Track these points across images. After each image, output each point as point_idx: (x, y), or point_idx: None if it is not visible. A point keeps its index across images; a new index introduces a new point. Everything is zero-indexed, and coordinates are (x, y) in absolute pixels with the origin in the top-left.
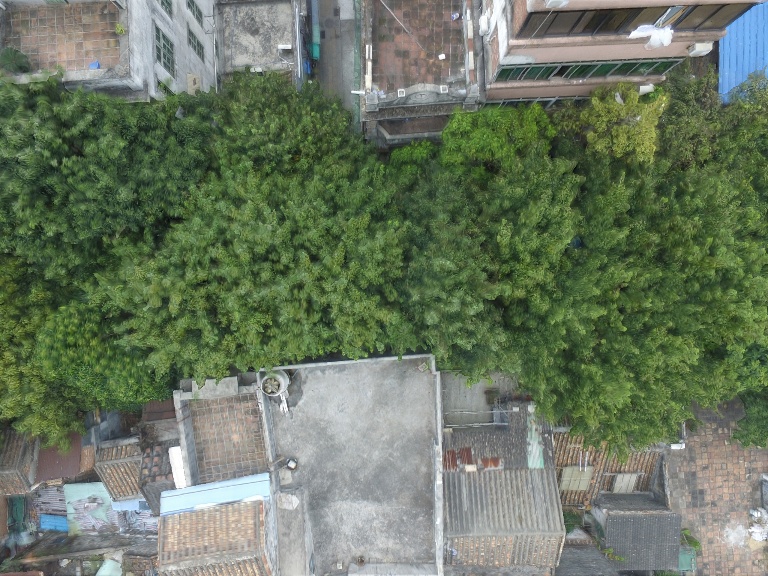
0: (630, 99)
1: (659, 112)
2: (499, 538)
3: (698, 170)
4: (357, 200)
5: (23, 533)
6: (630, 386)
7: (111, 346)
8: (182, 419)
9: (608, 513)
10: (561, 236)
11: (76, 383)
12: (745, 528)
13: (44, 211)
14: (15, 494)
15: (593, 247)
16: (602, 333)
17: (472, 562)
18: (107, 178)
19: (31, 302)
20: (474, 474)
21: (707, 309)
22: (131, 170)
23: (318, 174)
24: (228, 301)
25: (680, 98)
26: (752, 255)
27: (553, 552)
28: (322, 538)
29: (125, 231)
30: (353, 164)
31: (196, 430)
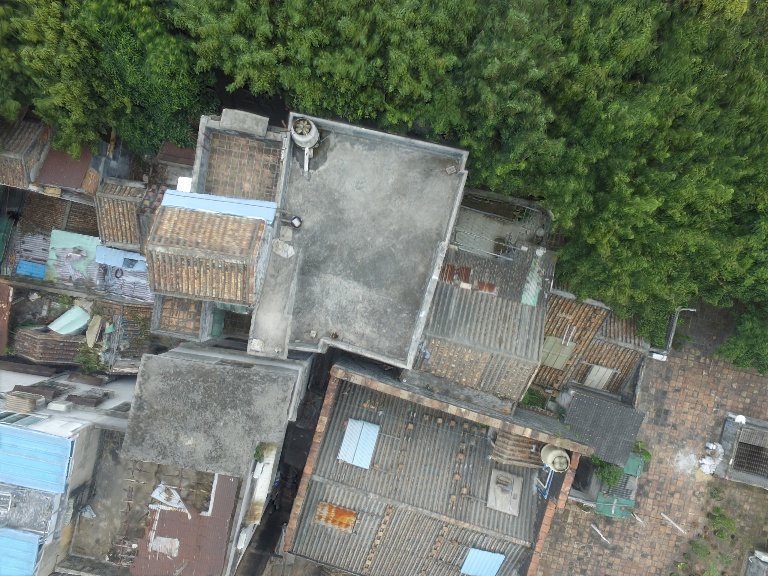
0: None
1: None
2: (475, 352)
3: None
4: None
5: None
6: (657, 205)
7: None
8: (202, 145)
9: (575, 394)
10: None
11: (115, 53)
12: (696, 458)
13: None
14: None
15: (657, 81)
16: (638, 173)
17: (440, 372)
18: None
19: None
20: (467, 292)
21: (751, 164)
22: None
23: None
24: (293, 4)
25: None
26: None
27: (522, 383)
28: (303, 305)
29: None
30: None
31: (211, 168)
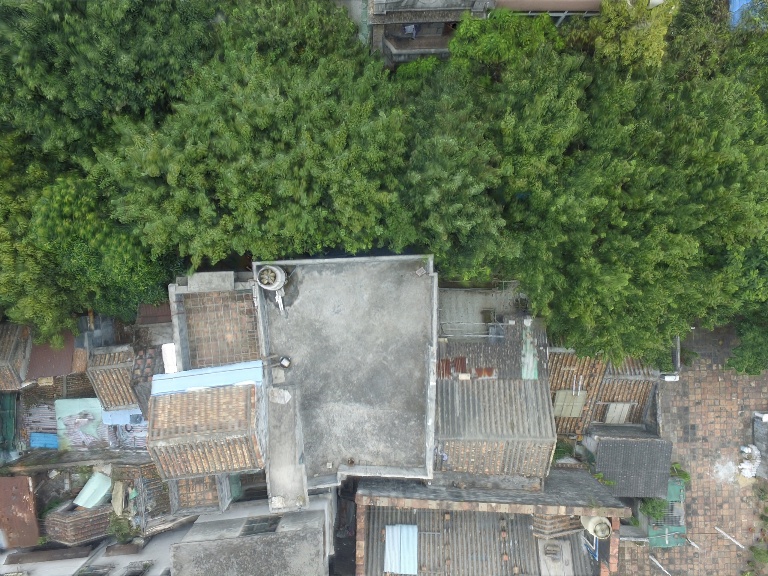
0: (640, 1)
1: (668, 19)
2: (490, 443)
3: (705, 81)
4: (361, 90)
5: (12, 453)
6: (628, 277)
7: (107, 224)
8: (176, 313)
9: (599, 439)
10: (565, 127)
11: (71, 261)
12: (735, 464)
13: (44, 75)
14: (6, 412)
15: (597, 147)
16: None
17: (462, 469)
18: (109, 42)
19: (28, 182)
20: (467, 382)
21: (708, 208)
22: (134, 42)
23: (323, 68)
24: (227, 177)
25: (690, 11)
26: (756, 151)
27: (543, 460)
28: (313, 439)
29: (126, 111)
30: (358, 68)
31: (190, 328)
